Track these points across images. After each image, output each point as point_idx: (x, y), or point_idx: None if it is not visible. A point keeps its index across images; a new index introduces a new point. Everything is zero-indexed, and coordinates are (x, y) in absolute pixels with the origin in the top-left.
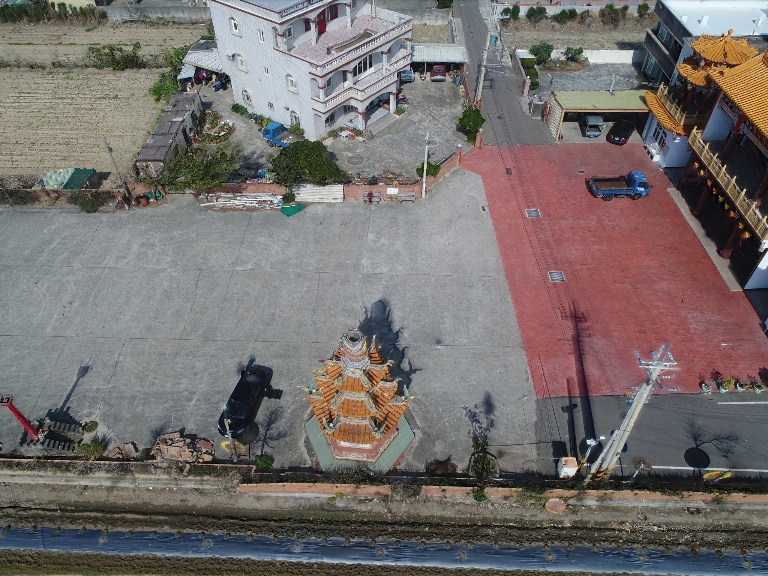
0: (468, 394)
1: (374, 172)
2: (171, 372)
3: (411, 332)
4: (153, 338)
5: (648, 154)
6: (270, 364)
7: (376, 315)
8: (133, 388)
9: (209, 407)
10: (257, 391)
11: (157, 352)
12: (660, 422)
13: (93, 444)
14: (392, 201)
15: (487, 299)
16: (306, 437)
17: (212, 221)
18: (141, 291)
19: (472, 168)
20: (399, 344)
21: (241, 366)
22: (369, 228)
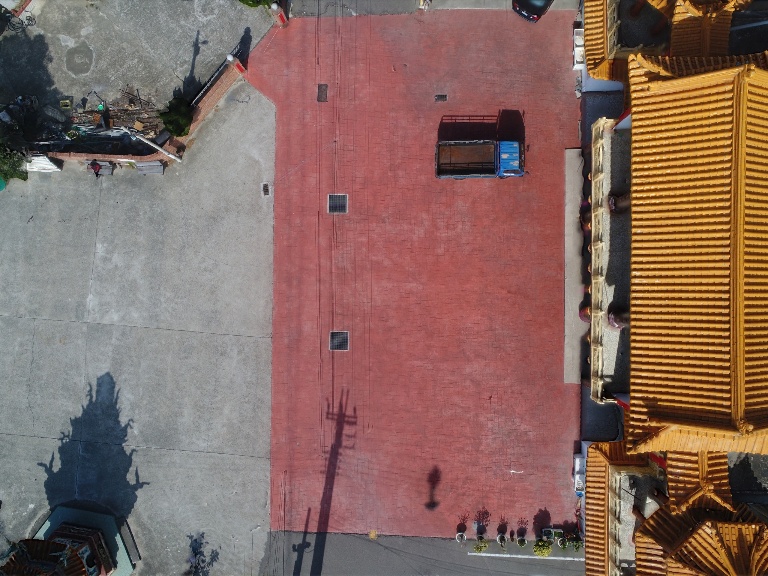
0: (196, 520)
1: (107, 95)
2: None
3: (142, 427)
4: None
5: (572, 48)
6: None
7: (102, 398)
8: None
9: None
10: None
11: None
12: (394, 572)
13: None
14: (133, 169)
15: (240, 378)
16: None
17: None
18: None
19: (264, 84)
20: (127, 445)
21: None
22: (98, 231)
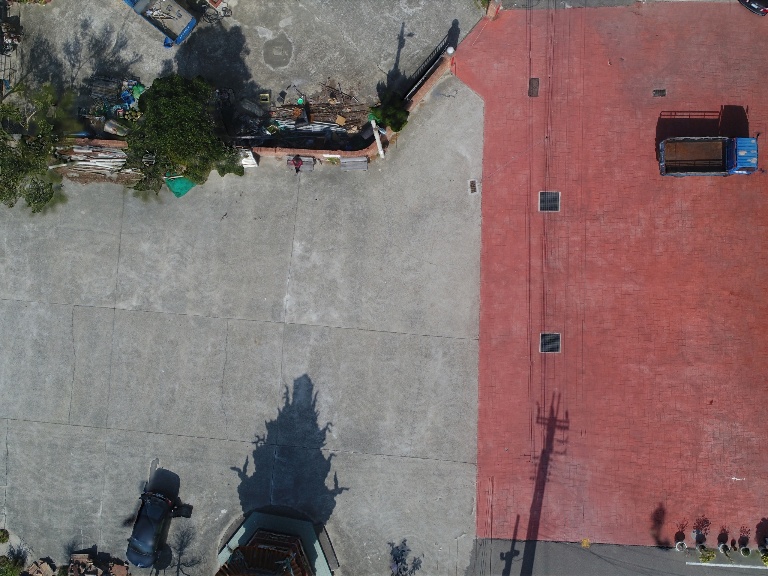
0: (398, 526)
1: (307, 88)
2: (68, 472)
3: (341, 431)
4: (38, 421)
5: None
6: (176, 469)
7: (299, 400)
8: (33, 491)
9: (117, 522)
10: (161, 525)
11: (47, 442)
12: None
13: (11, 557)
14: (333, 164)
15: (445, 381)
16: (220, 567)
17: (72, 204)
18: (7, 342)
19: (472, 78)
20: (325, 449)
21: (143, 469)
22: (295, 229)
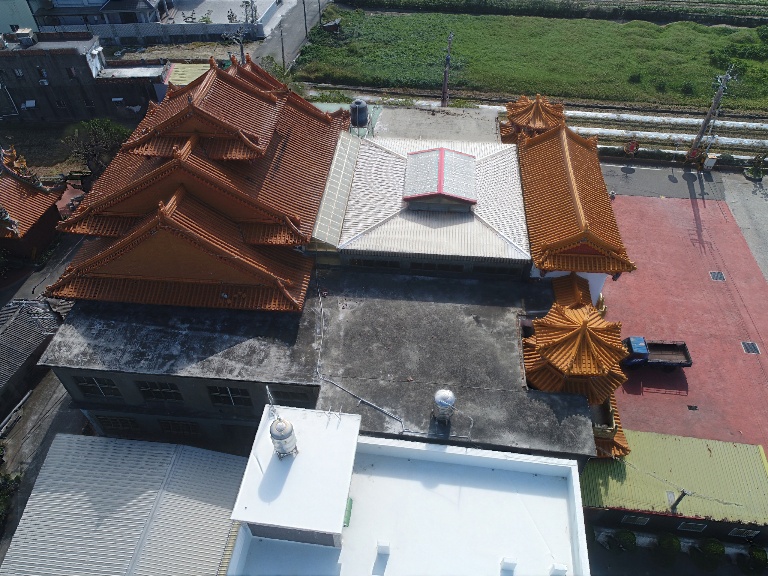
0: None
1: None
2: None
3: None
4: None
5: None
6: None
7: None
8: None
9: None
10: None
11: None
12: (646, 184)
13: None
14: None
15: None
16: None
17: None
18: None
19: None
20: None
21: None
22: None
